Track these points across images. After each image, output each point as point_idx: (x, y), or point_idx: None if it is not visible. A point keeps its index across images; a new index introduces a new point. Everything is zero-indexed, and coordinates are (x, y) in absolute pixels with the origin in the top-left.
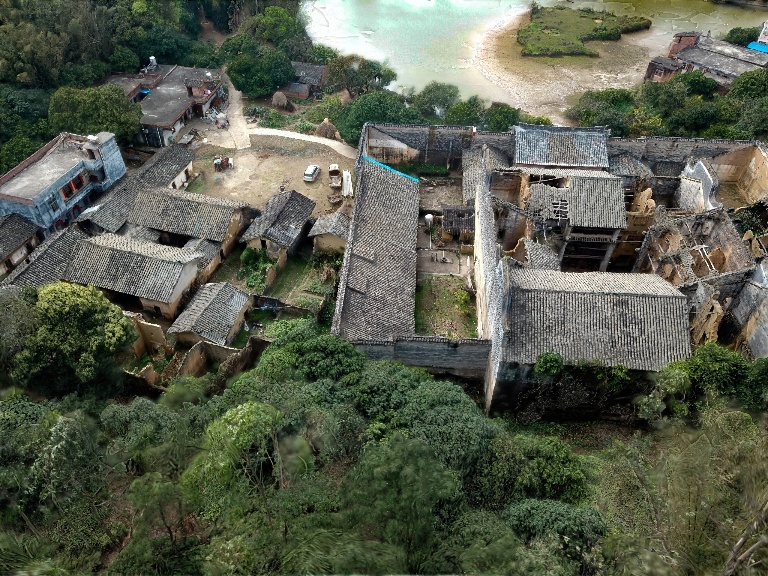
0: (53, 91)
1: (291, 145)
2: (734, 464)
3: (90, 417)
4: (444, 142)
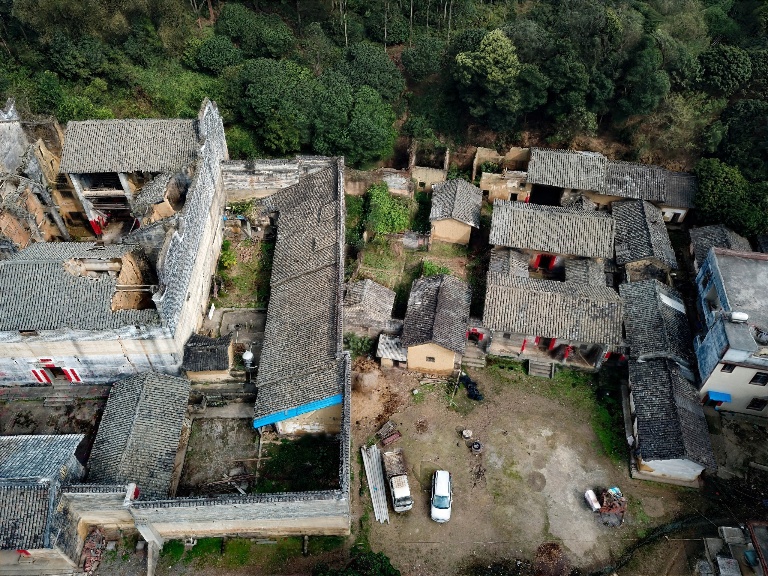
0: None
1: None
2: (144, 2)
3: None
4: None
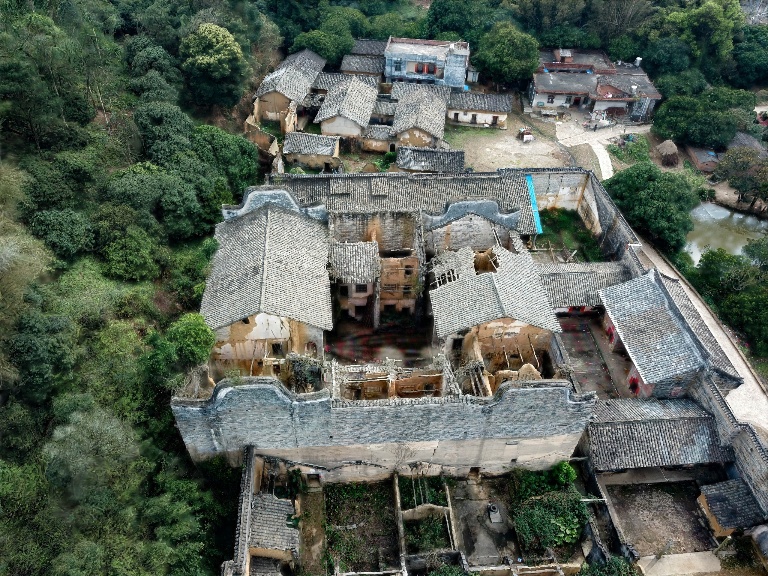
0: (532, 31)
1: (587, 167)
2: None
3: (168, 81)
4: (617, 239)
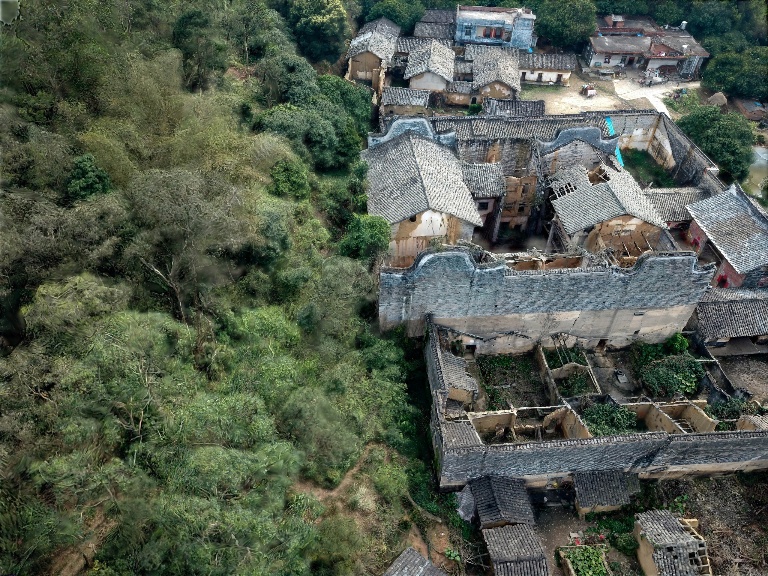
0: None
1: None
2: None
3: None
4: (693, 168)
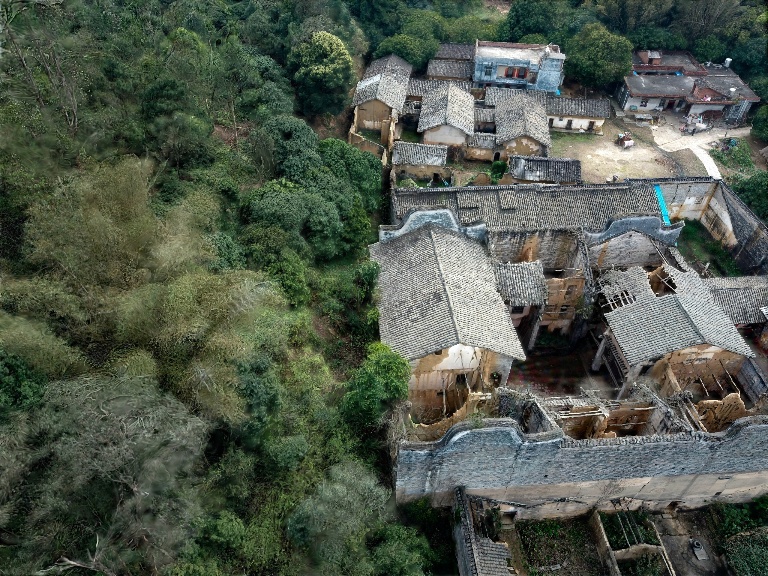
0: (616, 32)
1: (694, 174)
2: None
3: None
4: (761, 251)
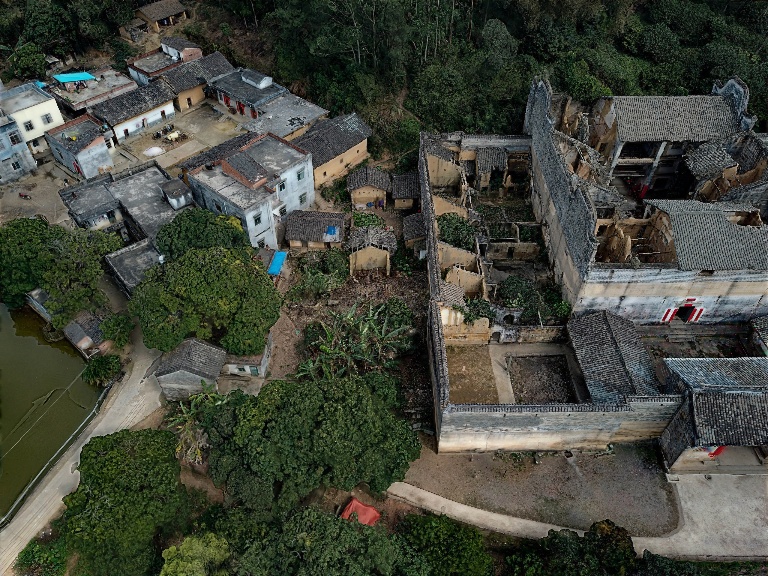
0: None
1: None
2: None
3: None
4: None
